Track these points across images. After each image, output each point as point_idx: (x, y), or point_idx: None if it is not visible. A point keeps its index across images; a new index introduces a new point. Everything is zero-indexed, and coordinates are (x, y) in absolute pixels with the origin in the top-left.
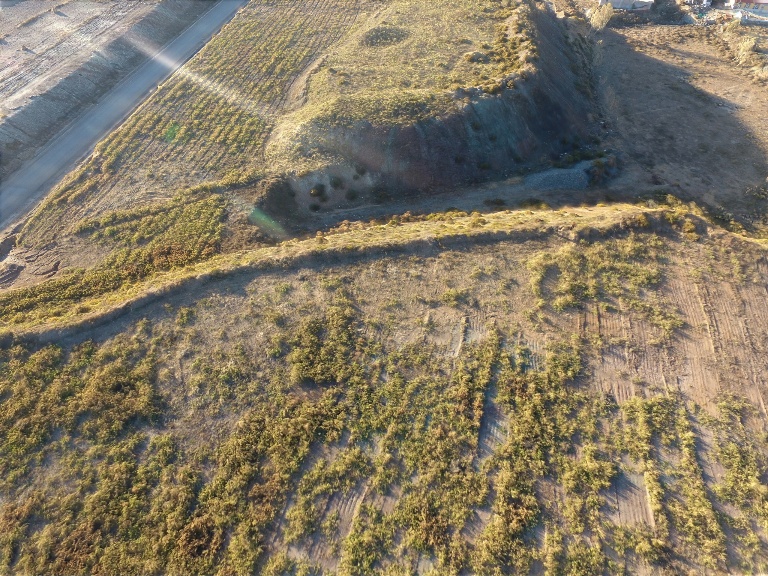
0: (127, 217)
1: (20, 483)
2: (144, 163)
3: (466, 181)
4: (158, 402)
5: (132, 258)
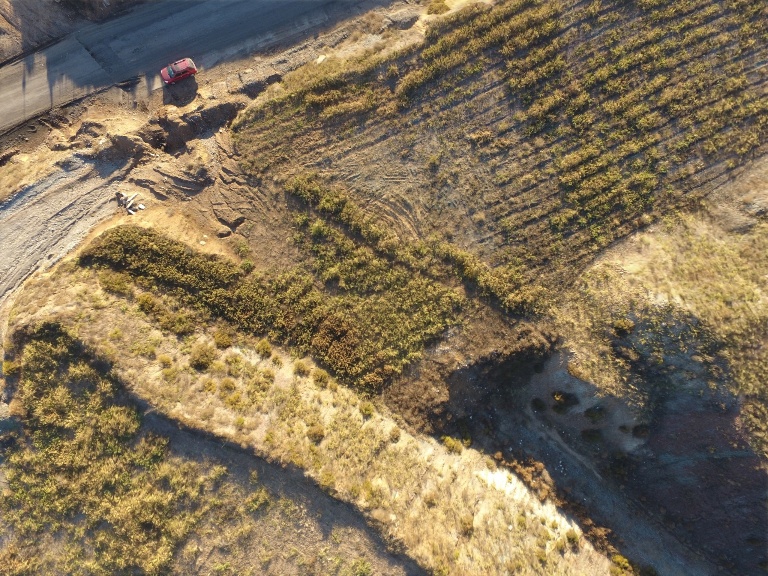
0: (350, 226)
1: (30, 536)
2: (450, 127)
3: (722, 558)
4: (165, 573)
5: (303, 305)
